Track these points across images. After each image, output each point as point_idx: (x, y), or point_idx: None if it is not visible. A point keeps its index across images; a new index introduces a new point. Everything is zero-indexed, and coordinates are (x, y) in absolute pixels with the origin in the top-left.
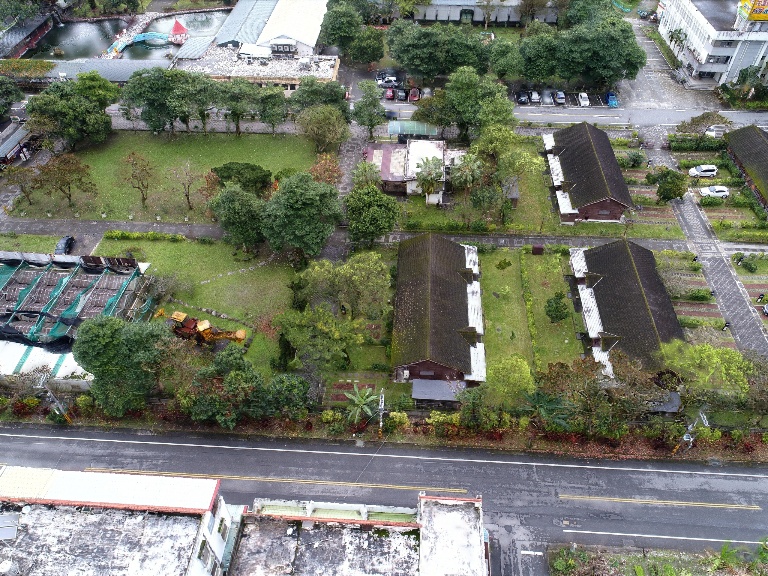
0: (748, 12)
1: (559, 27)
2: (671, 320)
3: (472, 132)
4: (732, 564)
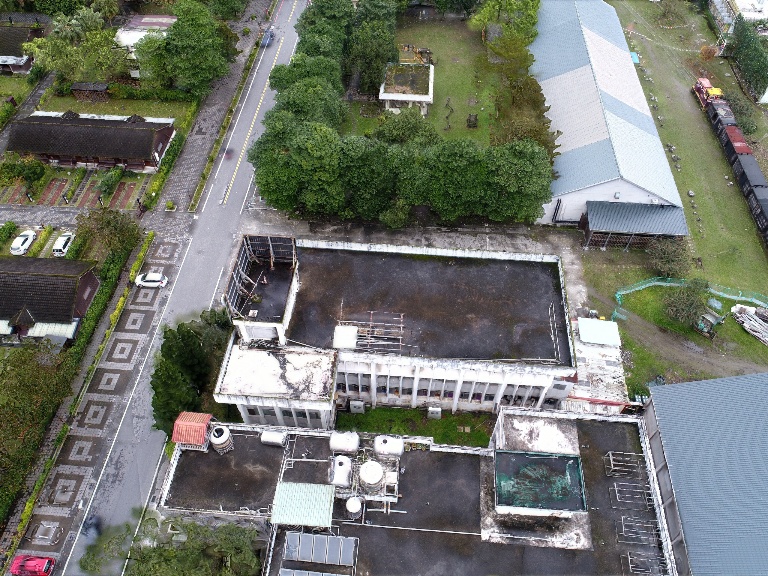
0: (254, 252)
1: None
2: None
3: None
4: None
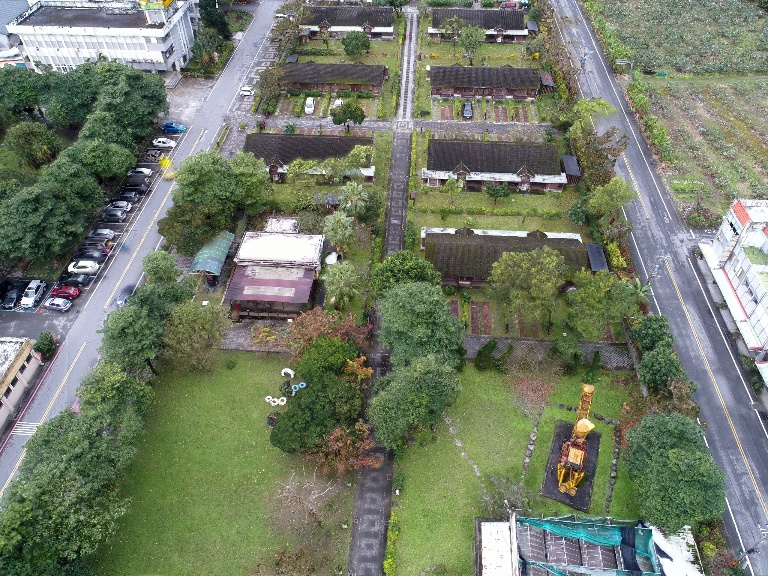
0: (161, 3)
1: (14, 124)
2: None
3: None
4: (660, 166)
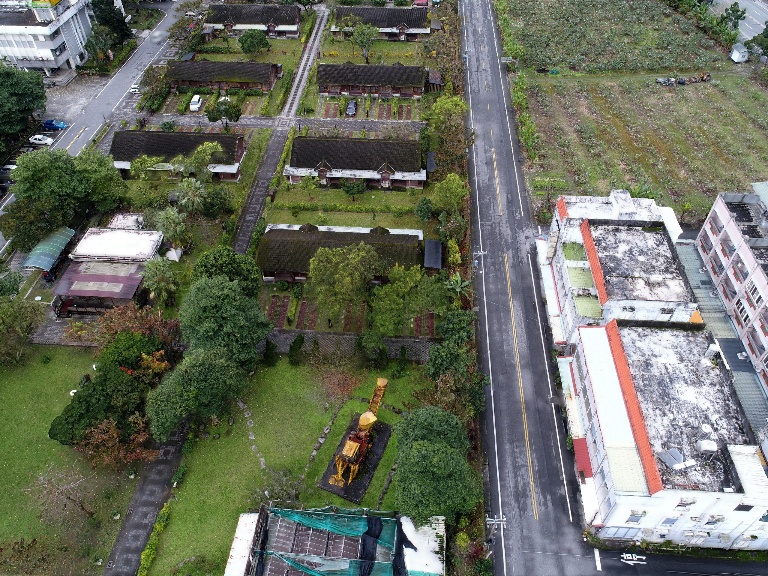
0: (47, 1)
1: None
2: (372, 139)
3: (96, 199)
4: (527, 163)
